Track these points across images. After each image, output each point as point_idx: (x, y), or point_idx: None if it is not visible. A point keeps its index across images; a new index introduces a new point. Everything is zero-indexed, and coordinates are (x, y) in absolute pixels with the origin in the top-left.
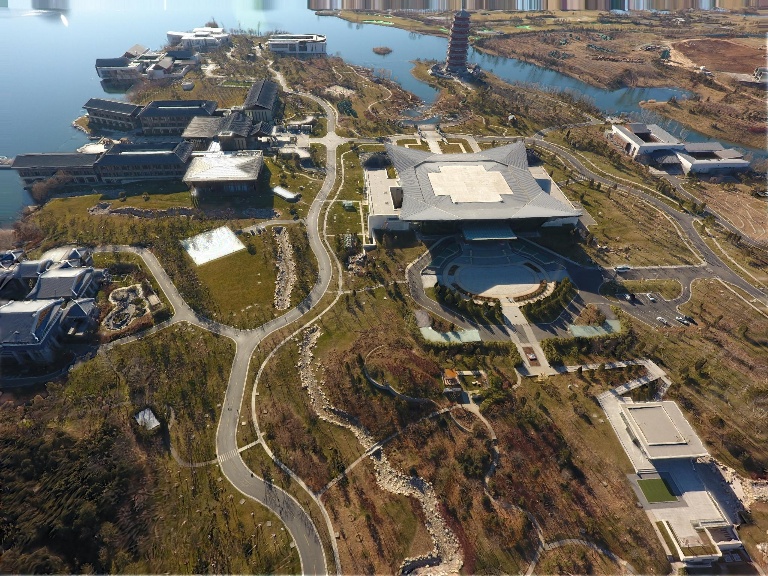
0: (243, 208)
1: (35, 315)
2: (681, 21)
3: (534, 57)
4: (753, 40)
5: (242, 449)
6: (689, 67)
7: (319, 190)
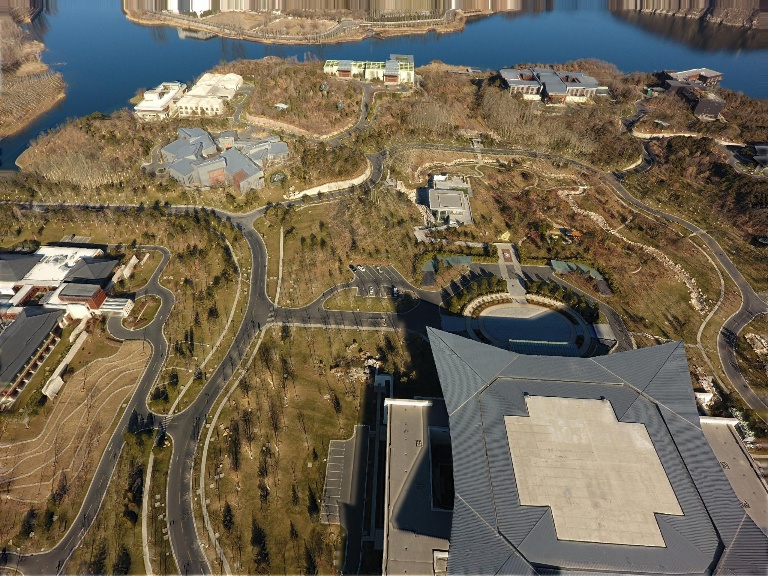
0: None
1: None
2: None
3: None
4: None
5: (694, 234)
6: None
7: None
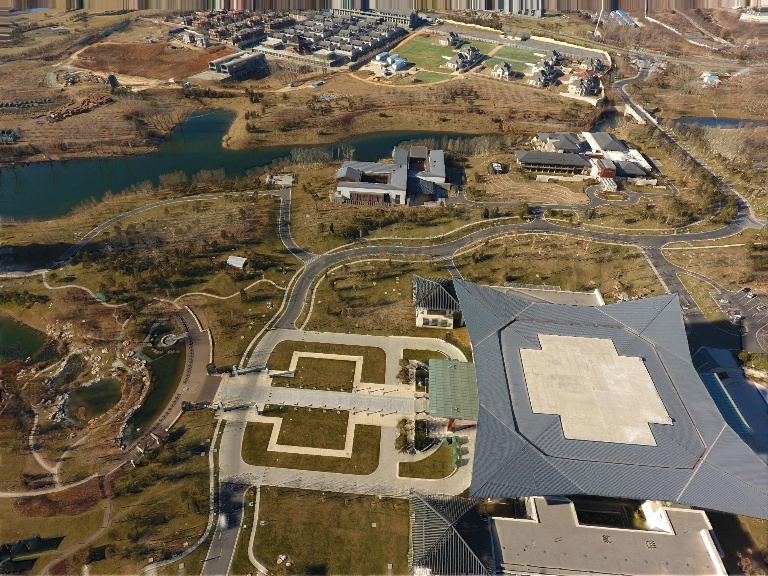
0: None
1: None
2: (7, 34)
3: None
4: (123, 34)
5: None
6: (159, 85)
7: None
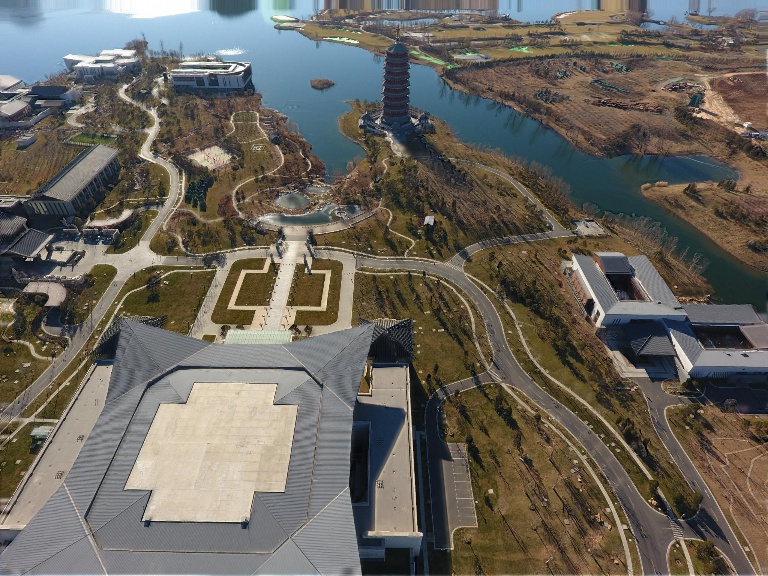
0: None
1: None
2: (729, 43)
3: (514, 99)
4: None
5: None
6: (728, 122)
7: (25, 388)
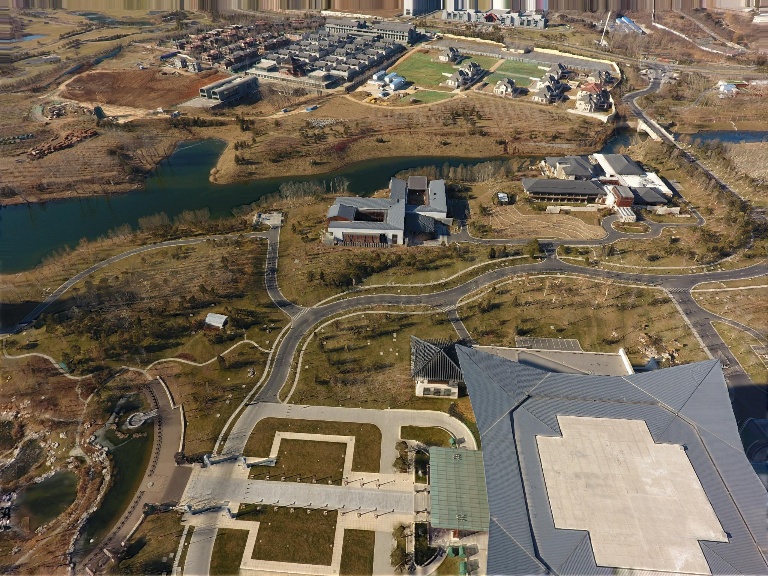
0: None
1: None
2: None
3: None
4: (114, 61)
5: None
6: (147, 115)
7: None
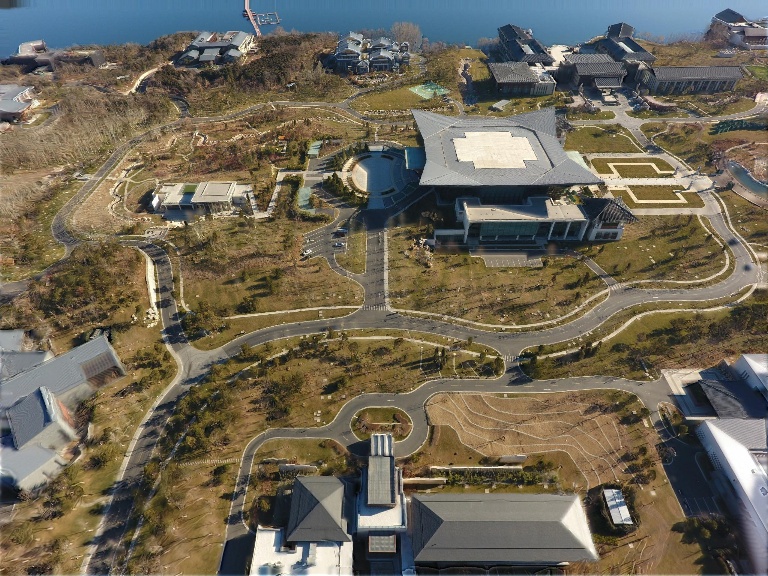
0: (476, 94)
1: (346, 48)
2: None
3: None
4: None
5: (273, 106)
6: None
7: None
